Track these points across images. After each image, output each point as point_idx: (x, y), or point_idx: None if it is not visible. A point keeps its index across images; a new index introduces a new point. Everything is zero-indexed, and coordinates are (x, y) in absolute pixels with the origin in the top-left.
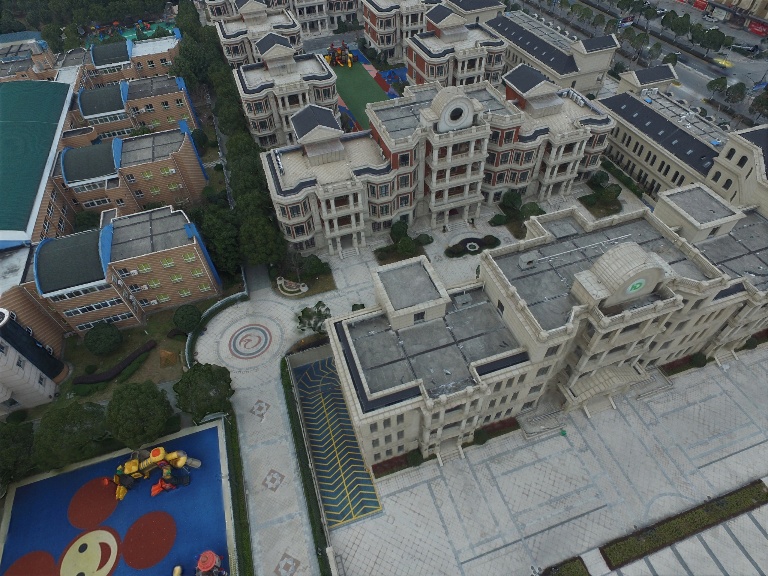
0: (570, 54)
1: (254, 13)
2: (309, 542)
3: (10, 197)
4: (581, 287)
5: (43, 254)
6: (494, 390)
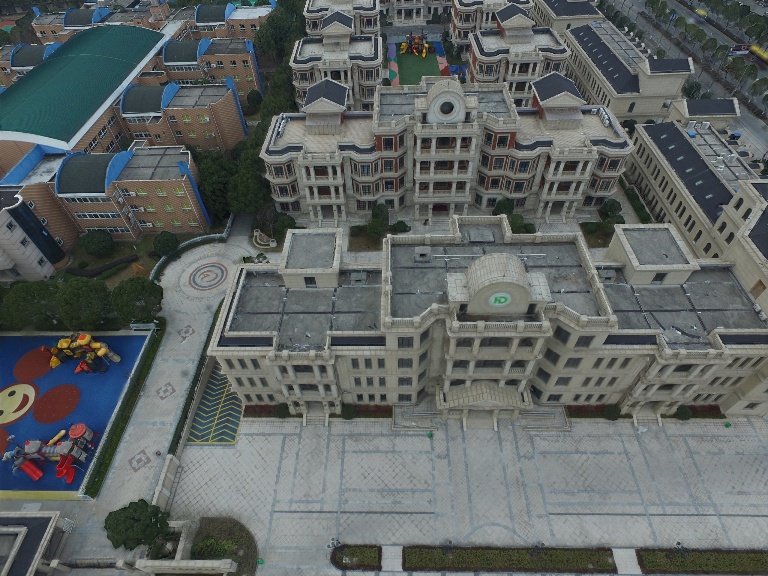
0: (635, 73)
1: None
2: (166, 448)
3: (70, 114)
4: None
5: (69, 162)
6: (354, 367)
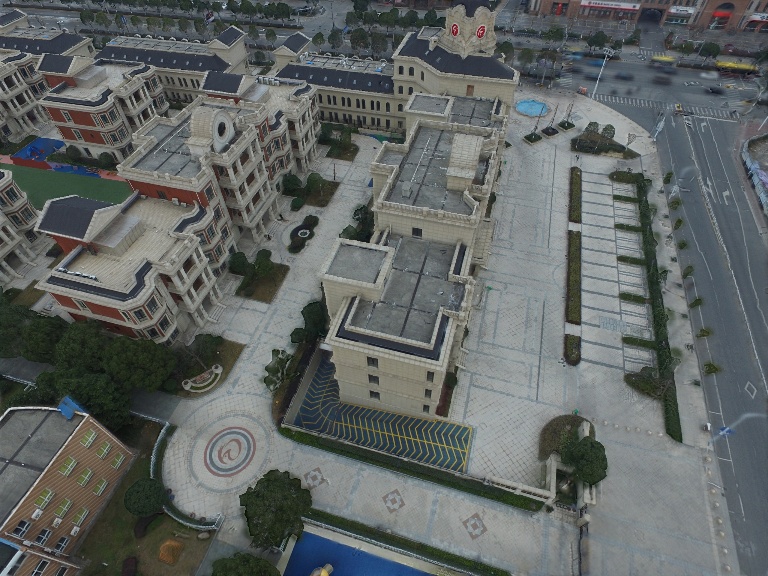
0: (213, 54)
1: None
2: (465, 497)
3: None
4: (456, 179)
5: None
6: None
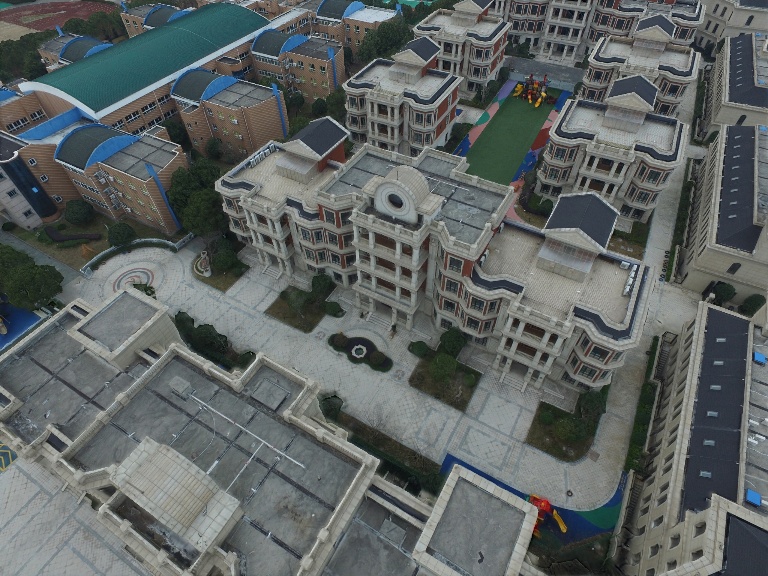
0: (758, 223)
1: (467, 13)
2: None
3: (120, 85)
4: None
5: (78, 133)
6: None
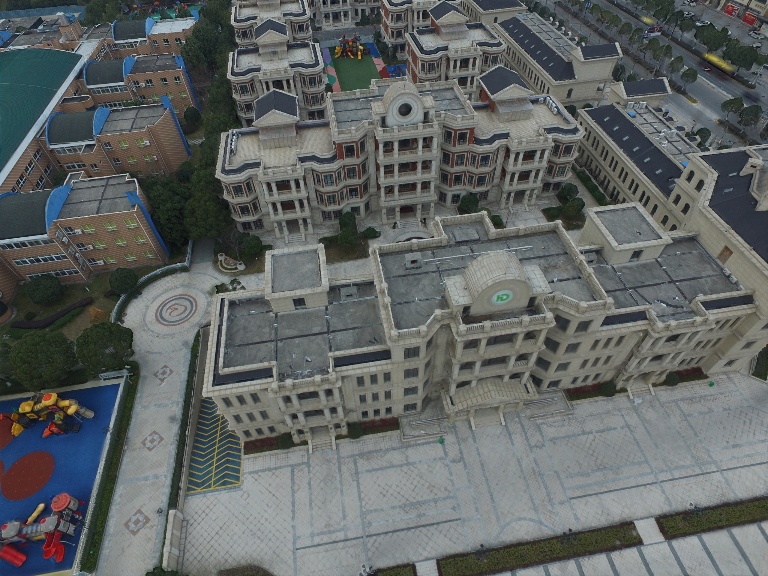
0: (569, 60)
1: None
2: (164, 503)
3: None
4: None
5: None
6: (359, 385)
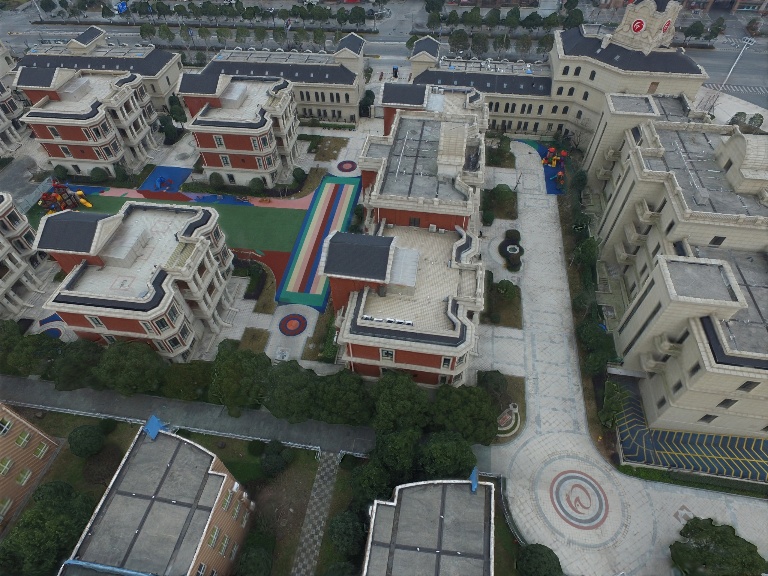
0: (340, 64)
1: None
2: None
3: None
4: (752, 182)
5: None
6: None
